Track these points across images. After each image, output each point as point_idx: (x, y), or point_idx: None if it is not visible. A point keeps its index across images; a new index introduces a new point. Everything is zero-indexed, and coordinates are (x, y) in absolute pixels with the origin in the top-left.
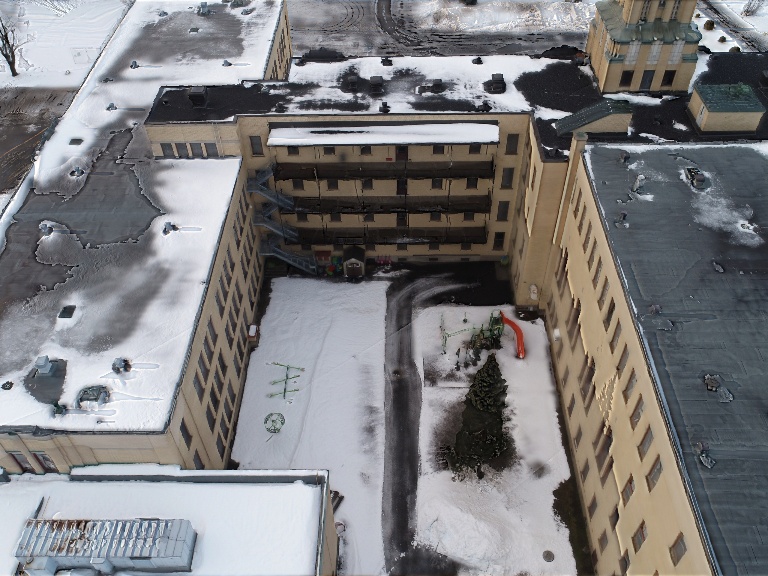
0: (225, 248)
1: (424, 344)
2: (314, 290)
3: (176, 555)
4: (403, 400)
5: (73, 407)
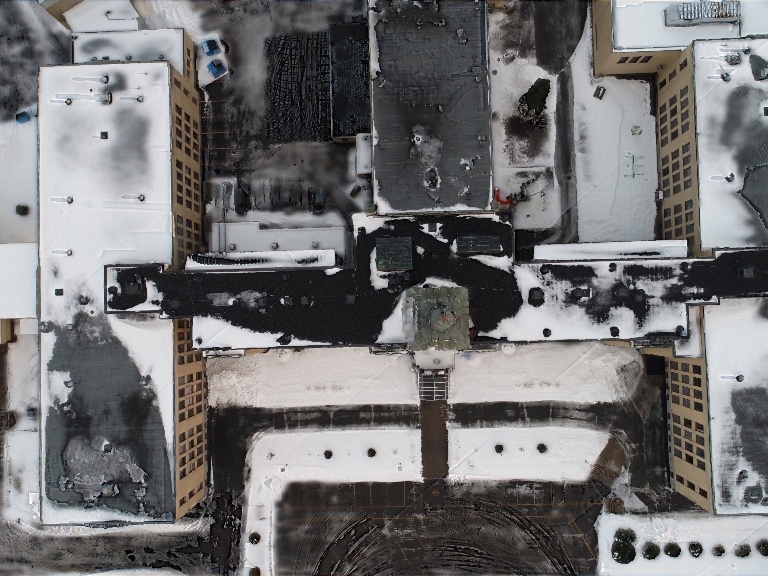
0: None
1: (554, 197)
2: (627, 239)
3: (673, 4)
4: (565, 158)
5: (742, 53)
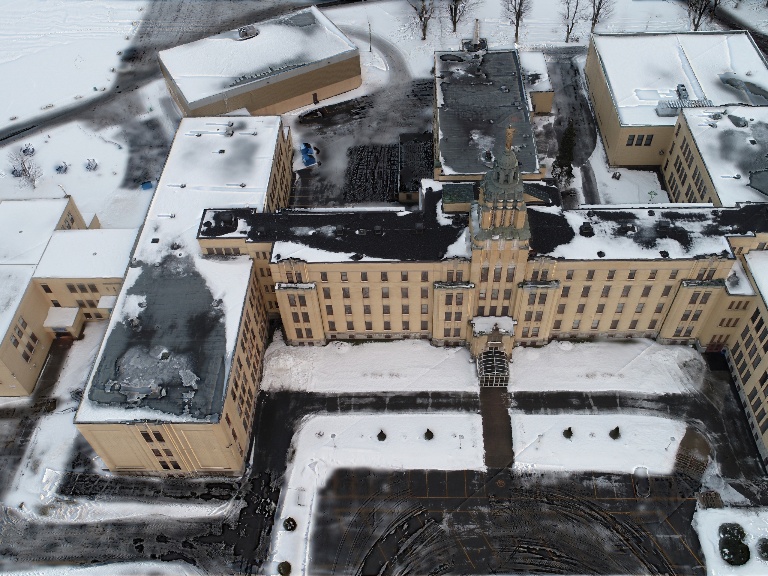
0: None
1: None
2: None
3: None
4: None
5: (721, 114)
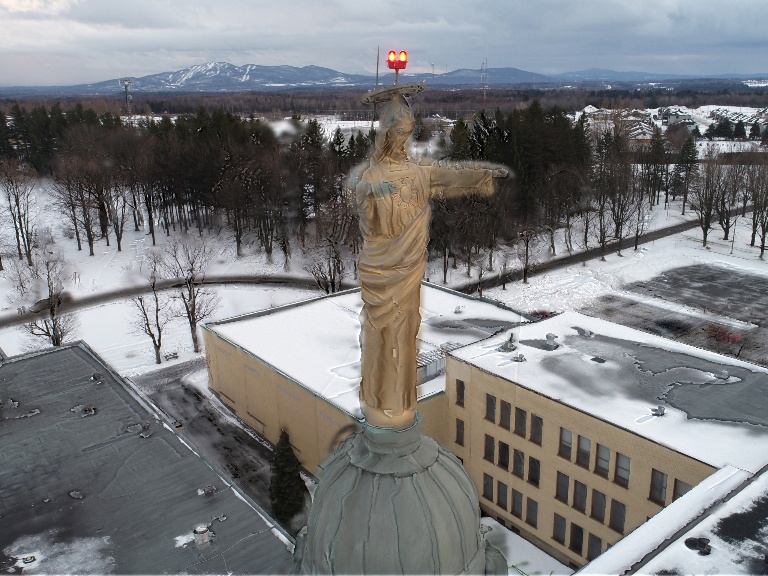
0: (617, 446)
1: None
2: None
3: None
4: None
5: None
